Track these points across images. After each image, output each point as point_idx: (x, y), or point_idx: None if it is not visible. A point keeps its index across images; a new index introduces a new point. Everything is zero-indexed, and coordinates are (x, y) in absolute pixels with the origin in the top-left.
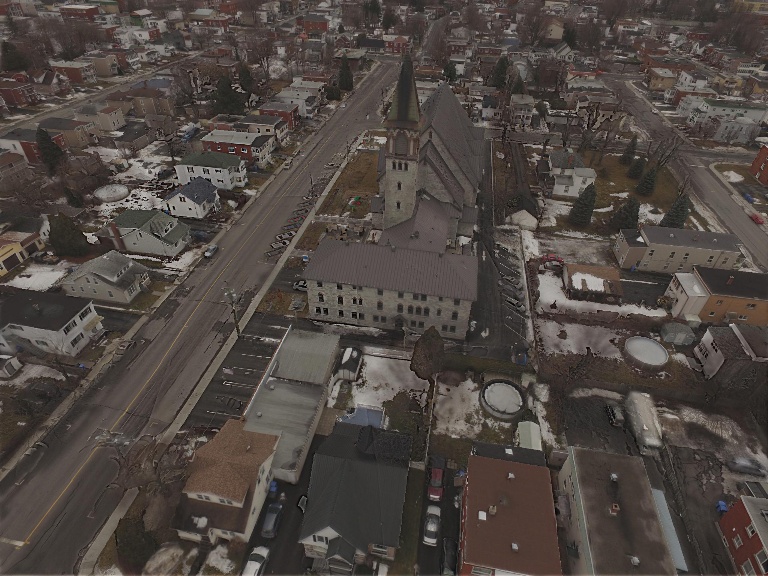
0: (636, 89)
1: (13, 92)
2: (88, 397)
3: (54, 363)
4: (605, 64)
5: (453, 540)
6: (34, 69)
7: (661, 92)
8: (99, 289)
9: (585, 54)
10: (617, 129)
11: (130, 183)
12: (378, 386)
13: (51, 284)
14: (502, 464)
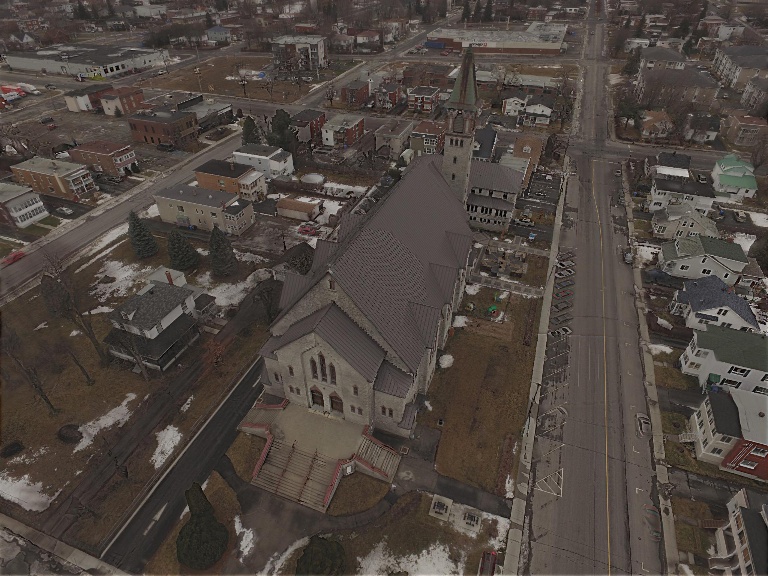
0: None
1: None
2: None
3: None
4: None
5: None
6: None
7: None
8: None
9: None
10: None
11: None
12: None
13: None
14: None
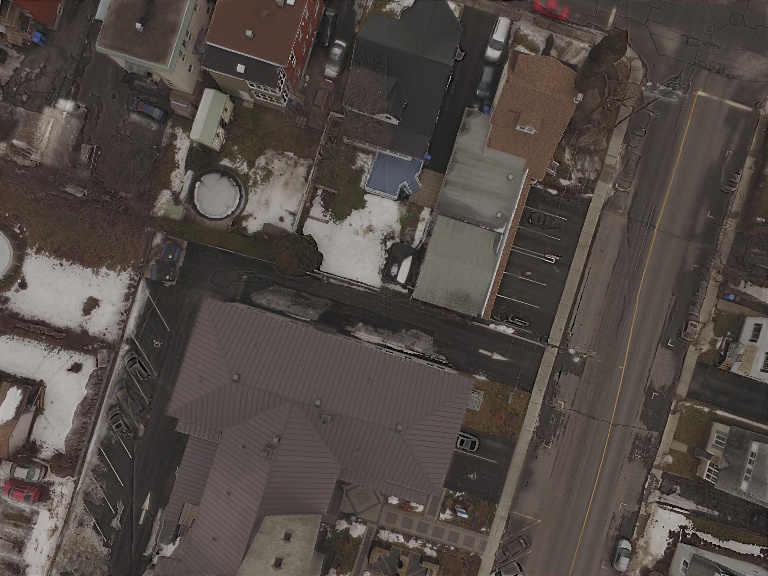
0: None
1: None
2: (705, 254)
3: None
4: None
5: (319, 43)
6: None
7: None
8: None
9: None
10: None
11: None
12: (368, 232)
13: None
14: (254, 51)
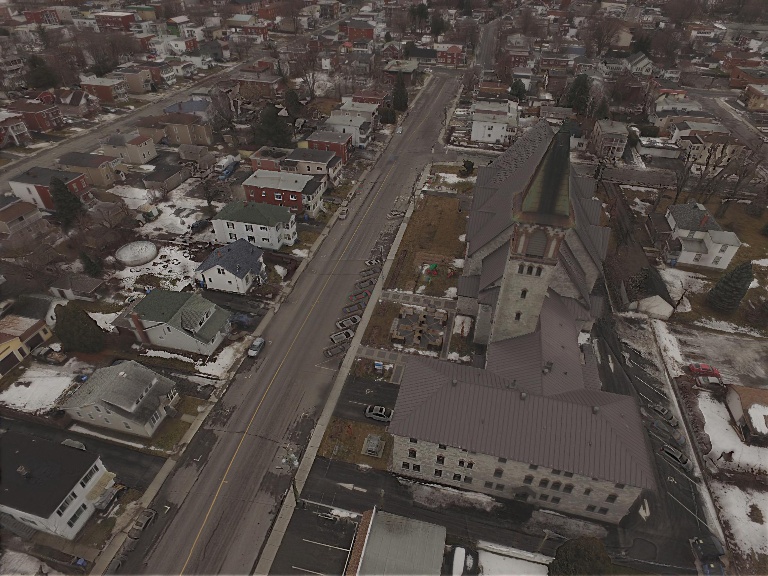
0: (732, 109)
1: (36, 116)
2: None
3: (43, 554)
4: (689, 78)
5: None
6: (63, 85)
7: (763, 113)
8: (112, 419)
9: (665, 66)
10: (752, 175)
11: (159, 238)
12: None
13: (53, 401)
14: None
